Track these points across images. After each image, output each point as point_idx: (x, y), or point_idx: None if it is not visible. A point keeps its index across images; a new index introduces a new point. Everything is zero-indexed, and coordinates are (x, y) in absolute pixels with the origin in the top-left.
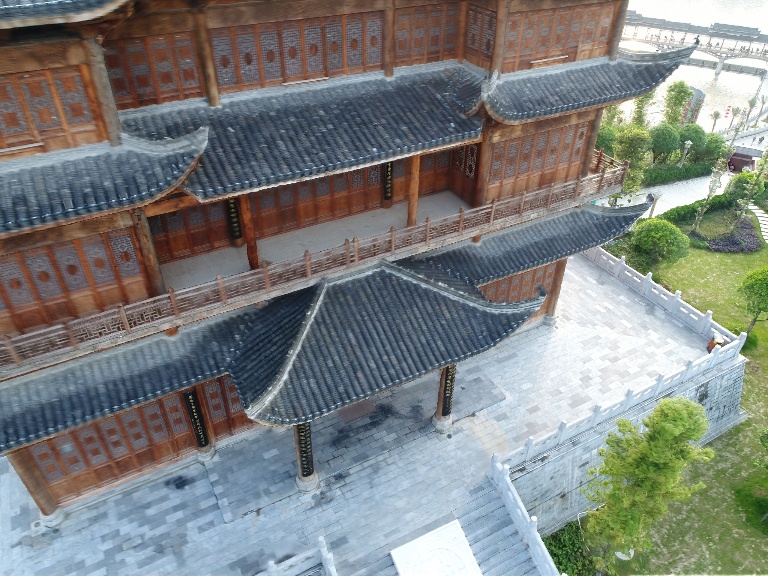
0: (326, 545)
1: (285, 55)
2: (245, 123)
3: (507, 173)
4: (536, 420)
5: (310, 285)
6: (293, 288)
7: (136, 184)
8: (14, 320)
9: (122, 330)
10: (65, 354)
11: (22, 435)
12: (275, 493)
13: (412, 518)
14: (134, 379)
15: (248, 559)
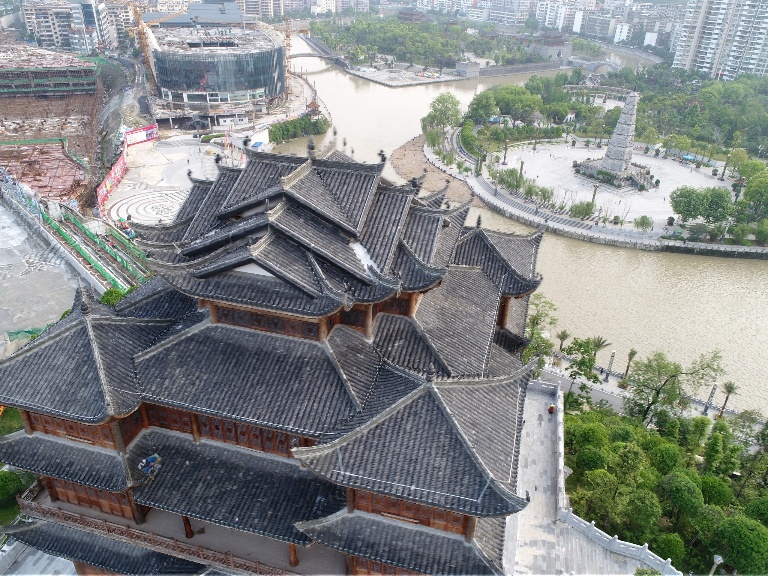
0: None
1: (238, 433)
2: (198, 461)
3: (373, 568)
4: None
5: (203, 563)
6: (193, 559)
7: (112, 480)
8: (77, 497)
9: (105, 531)
10: (80, 527)
11: (57, 550)
12: None
13: None
14: (111, 553)
15: None
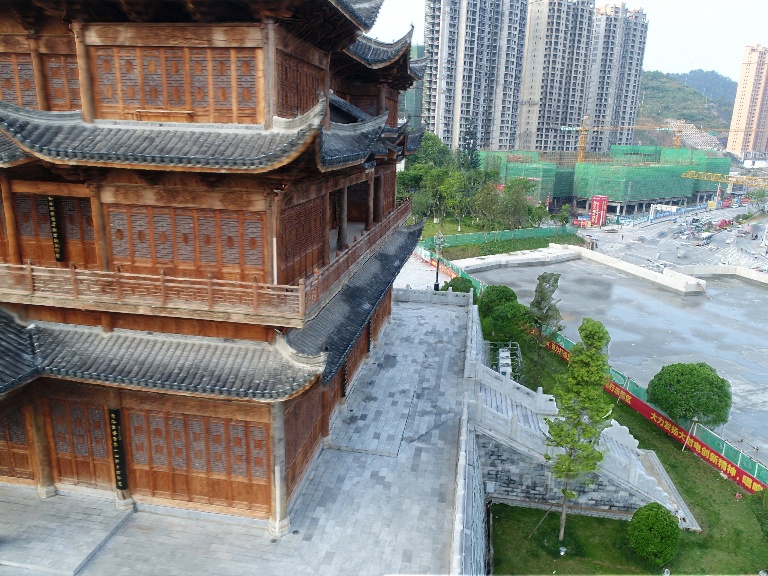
0: None
1: None
2: None
3: None
4: None
5: None
6: None
7: None
8: None
9: None
10: None
11: None
12: None
13: None
14: None
15: None
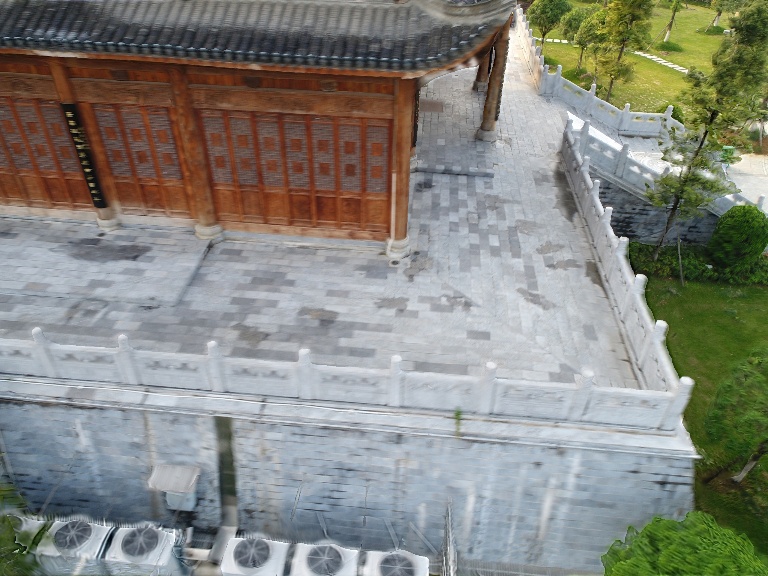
0: (550, 150)
1: None
2: None
3: None
4: (508, 72)
5: None
6: None
7: None
8: None
9: None
10: None
11: None
12: (486, 150)
13: (553, 122)
14: None
15: (537, 177)
